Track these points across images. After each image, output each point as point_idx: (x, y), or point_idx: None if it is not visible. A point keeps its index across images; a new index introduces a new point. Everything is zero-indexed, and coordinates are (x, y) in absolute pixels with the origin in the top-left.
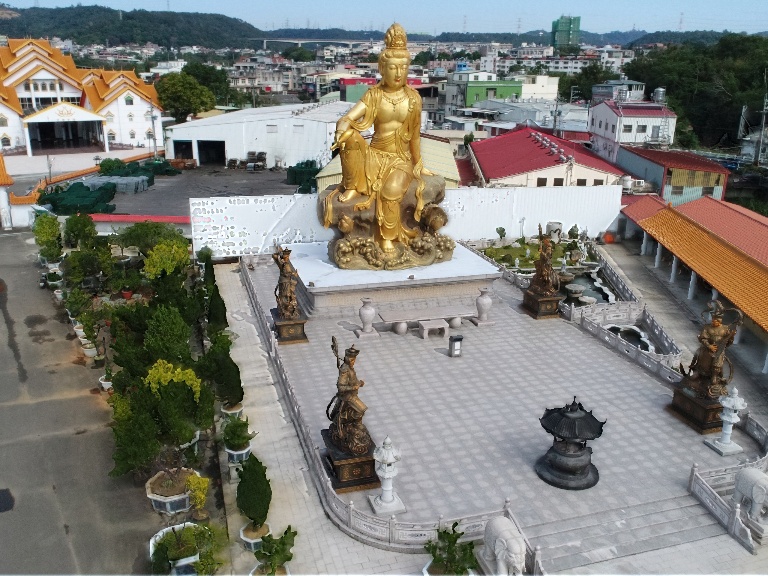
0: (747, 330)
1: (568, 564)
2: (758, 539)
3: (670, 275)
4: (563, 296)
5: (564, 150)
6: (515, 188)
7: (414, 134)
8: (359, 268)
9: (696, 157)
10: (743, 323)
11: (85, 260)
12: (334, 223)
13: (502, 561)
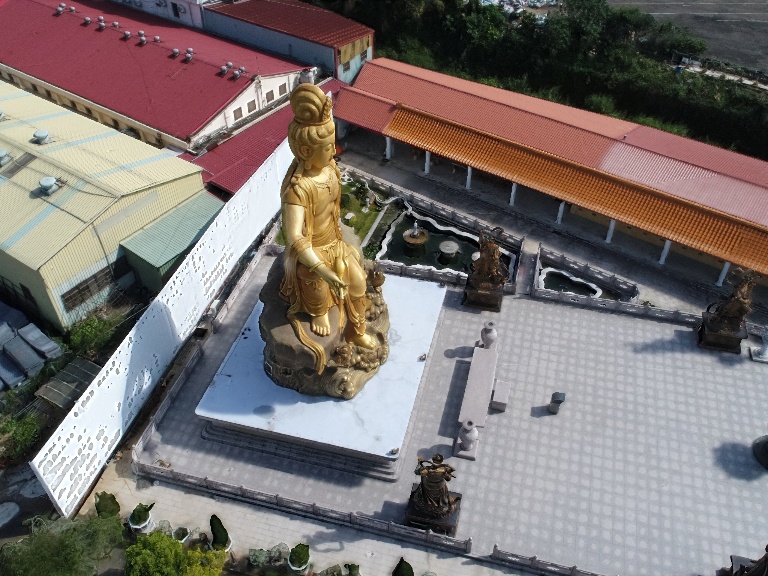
0: (589, 221)
1: None
2: None
3: (452, 179)
4: (426, 256)
5: (160, 37)
6: (275, 153)
7: None
8: (364, 384)
9: (287, 2)
10: (577, 215)
11: None
12: None
13: None
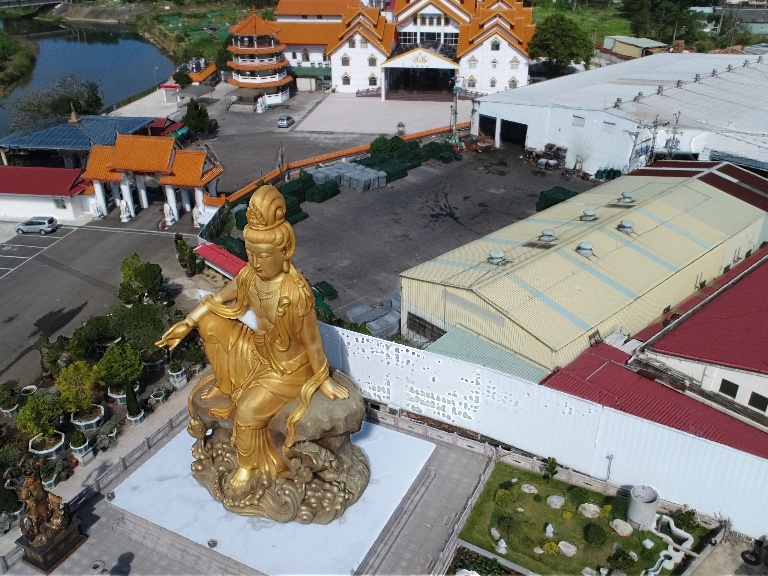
0: None
1: None
2: None
3: None
4: None
5: None
6: (603, 407)
7: (303, 339)
8: (204, 485)
9: None
10: None
11: (58, 343)
12: (196, 417)
13: None
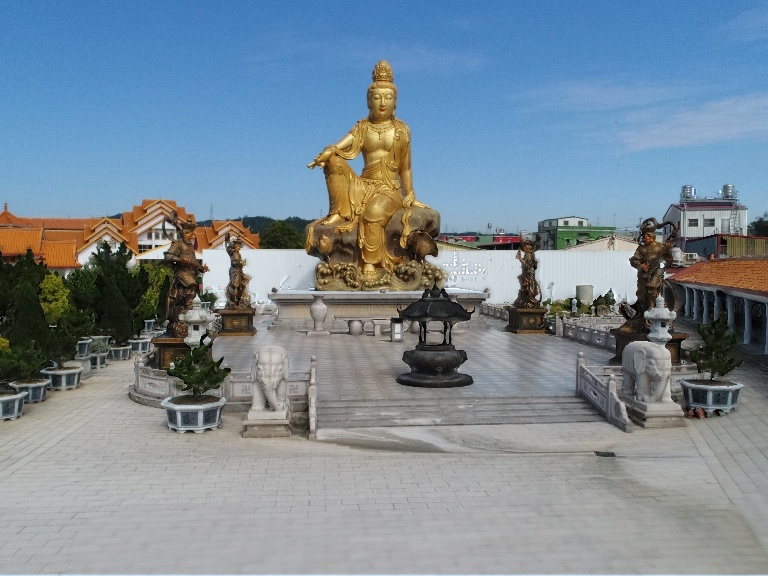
0: None
1: (366, 423)
2: (642, 422)
3: None
4: None
5: None
6: None
7: (403, 165)
8: (336, 289)
9: None
10: None
11: None
12: (315, 246)
13: (256, 384)
